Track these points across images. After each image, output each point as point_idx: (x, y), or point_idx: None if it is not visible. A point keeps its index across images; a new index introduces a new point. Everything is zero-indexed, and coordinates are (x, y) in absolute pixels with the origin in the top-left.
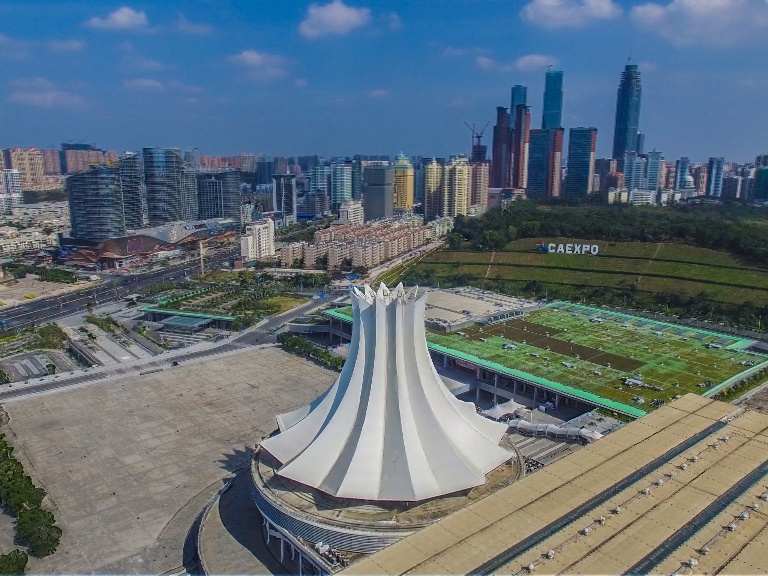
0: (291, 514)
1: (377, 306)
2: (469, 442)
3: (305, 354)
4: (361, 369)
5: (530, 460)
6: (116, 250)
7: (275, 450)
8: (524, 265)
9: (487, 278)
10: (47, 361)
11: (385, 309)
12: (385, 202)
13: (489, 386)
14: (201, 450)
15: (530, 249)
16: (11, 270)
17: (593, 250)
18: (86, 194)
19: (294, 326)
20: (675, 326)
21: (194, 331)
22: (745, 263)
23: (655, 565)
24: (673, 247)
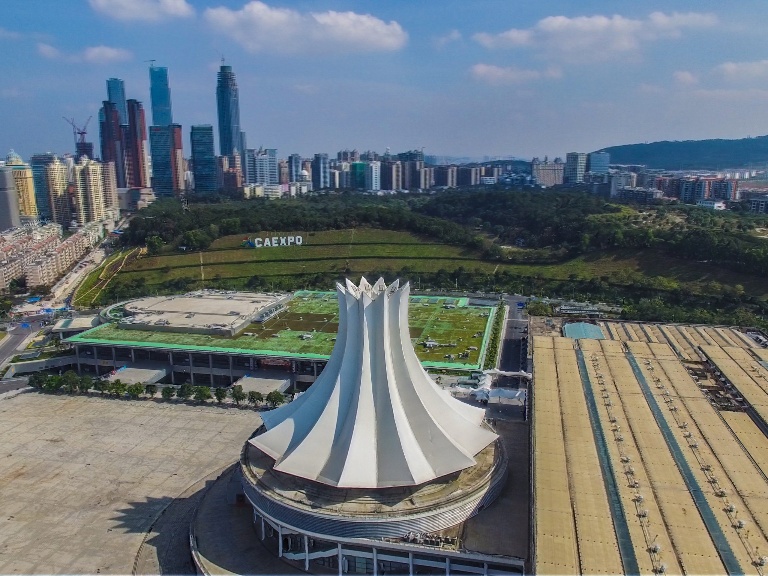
0: (371, 520)
1: (385, 299)
2: (454, 409)
3: (81, 391)
4: (368, 365)
5: None
6: None
7: (297, 470)
8: (237, 262)
9: (205, 279)
10: None
11: (388, 301)
12: (10, 210)
13: (308, 377)
14: (75, 525)
15: (237, 246)
16: None
17: (298, 241)
18: None
19: (22, 365)
20: None
21: None
22: (424, 239)
23: (677, 443)
24: (364, 232)
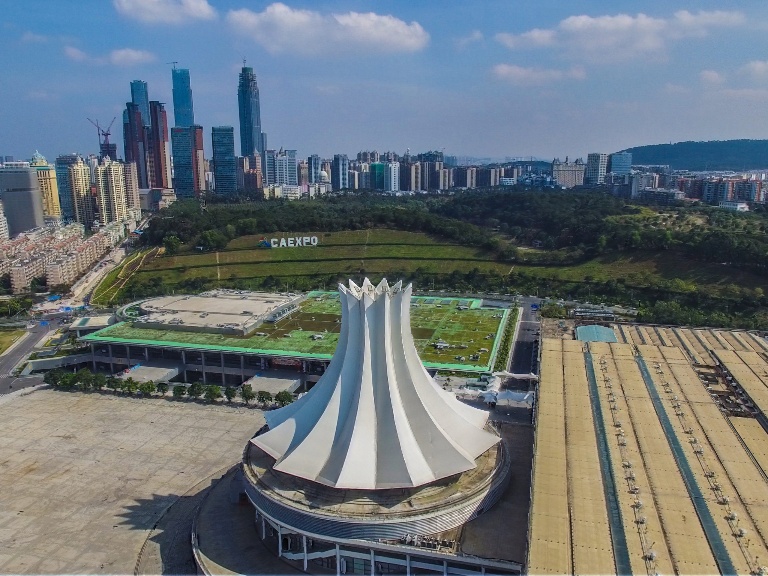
0: (368, 521)
1: (386, 300)
2: (457, 411)
3: (95, 389)
4: (369, 366)
5: None
6: None
7: (296, 470)
8: (253, 262)
9: (221, 279)
10: None
11: (389, 302)
12: (34, 210)
13: (318, 377)
14: (82, 521)
15: (253, 246)
16: None
17: (313, 241)
18: None
19: (39, 362)
20: (421, 297)
21: None
22: (439, 240)
23: (681, 449)
24: (380, 232)
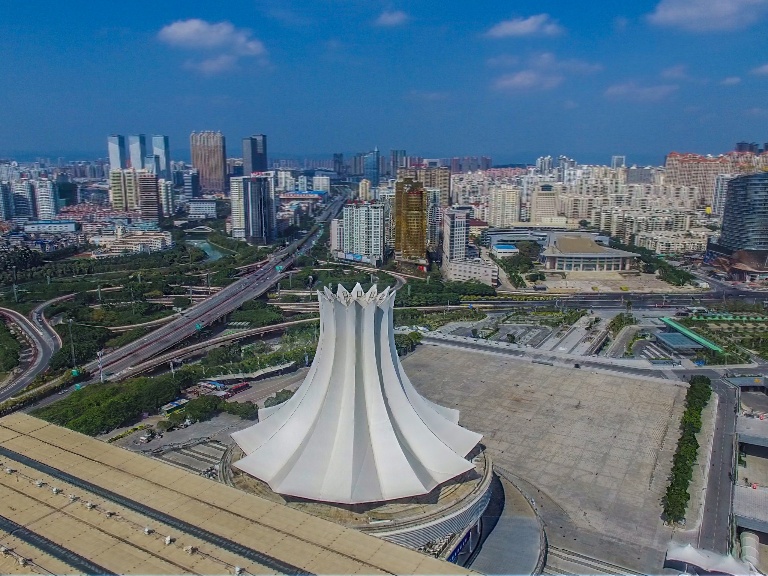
0: None
1: None
2: (341, 466)
3: None
4: None
5: (431, 549)
6: (751, 262)
7: None
8: None
9: None
10: (531, 335)
11: None
12: None
13: None
14: None
15: None
16: (644, 264)
17: None
18: (735, 200)
19: None
20: None
21: (683, 353)
22: None
23: (90, 574)
24: None
